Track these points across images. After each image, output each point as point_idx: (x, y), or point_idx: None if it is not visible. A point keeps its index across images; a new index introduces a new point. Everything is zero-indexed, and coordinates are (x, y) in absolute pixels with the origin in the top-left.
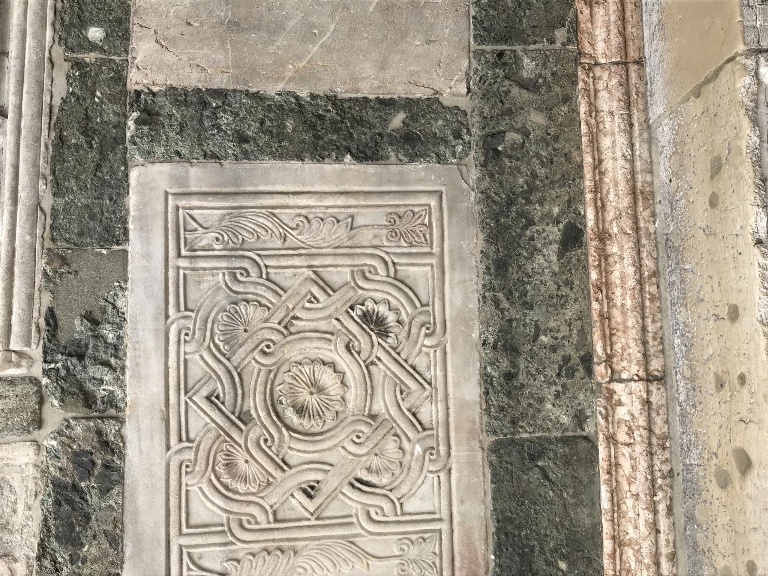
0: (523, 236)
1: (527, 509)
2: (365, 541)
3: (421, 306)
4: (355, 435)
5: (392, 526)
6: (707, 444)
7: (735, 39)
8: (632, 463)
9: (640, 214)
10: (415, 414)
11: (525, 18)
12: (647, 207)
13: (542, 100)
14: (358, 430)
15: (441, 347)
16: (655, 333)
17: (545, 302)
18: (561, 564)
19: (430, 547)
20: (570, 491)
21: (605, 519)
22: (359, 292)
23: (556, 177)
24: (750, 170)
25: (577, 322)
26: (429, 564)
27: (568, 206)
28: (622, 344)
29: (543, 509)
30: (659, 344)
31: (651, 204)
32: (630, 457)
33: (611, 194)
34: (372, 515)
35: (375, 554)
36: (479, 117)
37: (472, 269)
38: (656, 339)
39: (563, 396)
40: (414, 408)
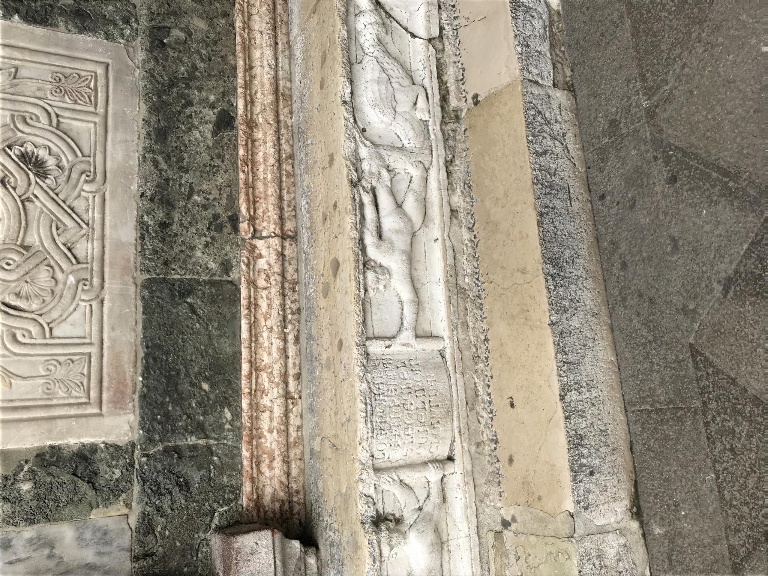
0: (182, 113)
1: (175, 338)
2: (9, 361)
3: (82, 156)
4: (5, 262)
5: (39, 348)
6: (318, 270)
7: None
8: (268, 302)
9: (281, 111)
10: (70, 249)
11: None
12: (286, 106)
13: (203, 10)
14: (9, 258)
15: (100, 193)
16: (289, 201)
17: (199, 169)
18: (204, 385)
19: (78, 368)
20: (215, 325)
21: (244, 347)
22: (18, 134)
23: (213, 72)
24: (340, 53)
25: (227, 188)
26: (76, 383)
27: (223, 97)
28: (263, 209)
29: (190, 338)
30: (292, 210)
31: (289, 104)
32: (266, 298)
33: (258, 93)
34: (19, 337)
35: (19, 374)
36: (147, 11)
37: (133, 132)
38: (290, 206)
39: (212, 246)
40: (69, 243)
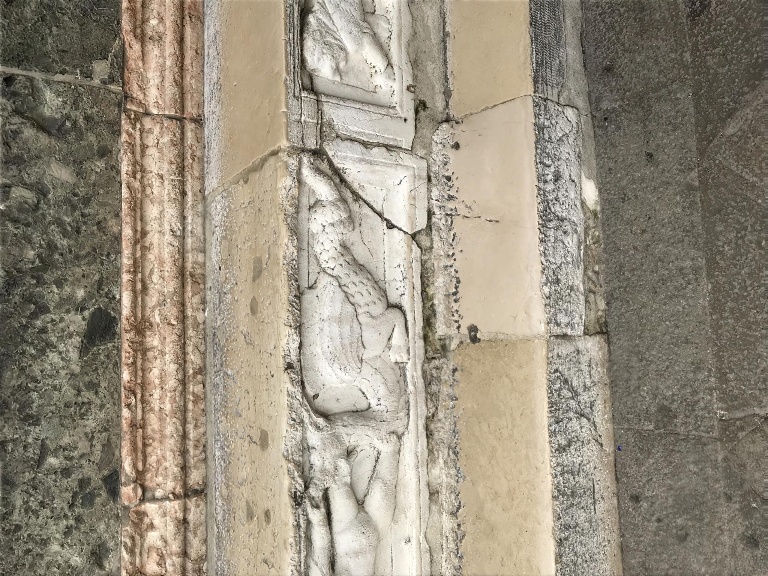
0: (31, 328)
1: None
2: None
3: None
4: None
5: None
6: None
7: (279, 131)
8: None
9: (188, 301)
10: None
11: (51, 37)
12: (197, 293)
13: (69, 149)
14: None
15: None
16: (197, 441)
17: (58, 414)
18: None
19: None
20: None
21: None
22: None
23: (84, 251)
24: (285, 284)
25: (102, 435)
26: None
27: (98, 288)
28: (158, 457)
29: None
30: (201, 453)
31: (202, 289)
32: None
33: (155, 275)
34: None
35: None
36: None
37: None
38: (198, 448)
39: (77, 533)
40: None
